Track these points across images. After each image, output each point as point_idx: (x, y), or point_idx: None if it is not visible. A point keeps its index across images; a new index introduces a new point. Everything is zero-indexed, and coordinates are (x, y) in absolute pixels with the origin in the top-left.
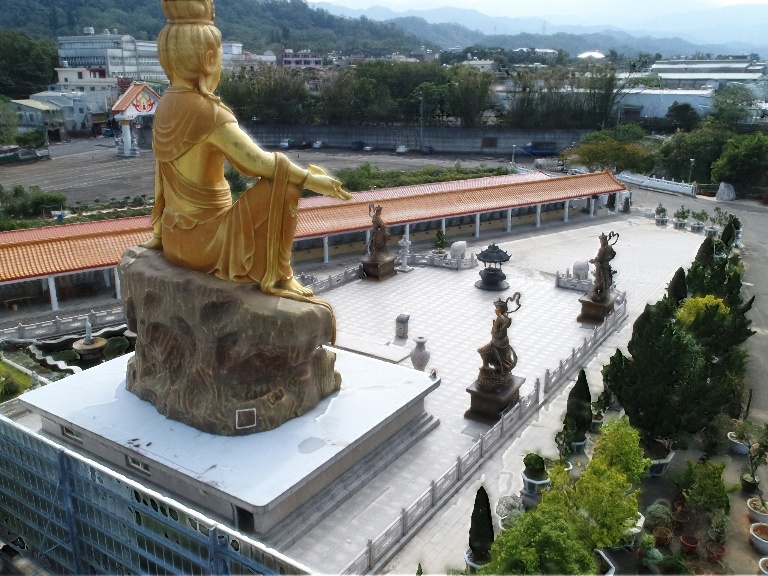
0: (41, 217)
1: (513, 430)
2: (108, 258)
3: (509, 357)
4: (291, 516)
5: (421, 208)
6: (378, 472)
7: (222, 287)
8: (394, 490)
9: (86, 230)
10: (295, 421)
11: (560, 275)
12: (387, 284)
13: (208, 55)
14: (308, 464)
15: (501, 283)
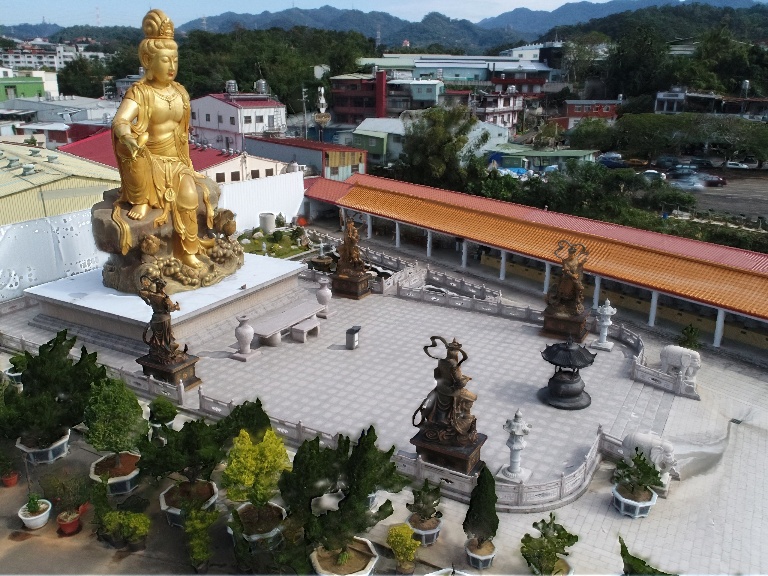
0: (659, 212)
1: (134, 391)
2: (423, 220)
3: (162, 337)
4: (52, 318)
5: (761, 297)
6: (97, 343)
7: (106, 192)
8: (74, 349)
9: (484, 204)
10: (113, 290)
11: (613, 437)
12: (531, 338)
13: (146, 57)
14: (56, 295)
15: (559, 396)
